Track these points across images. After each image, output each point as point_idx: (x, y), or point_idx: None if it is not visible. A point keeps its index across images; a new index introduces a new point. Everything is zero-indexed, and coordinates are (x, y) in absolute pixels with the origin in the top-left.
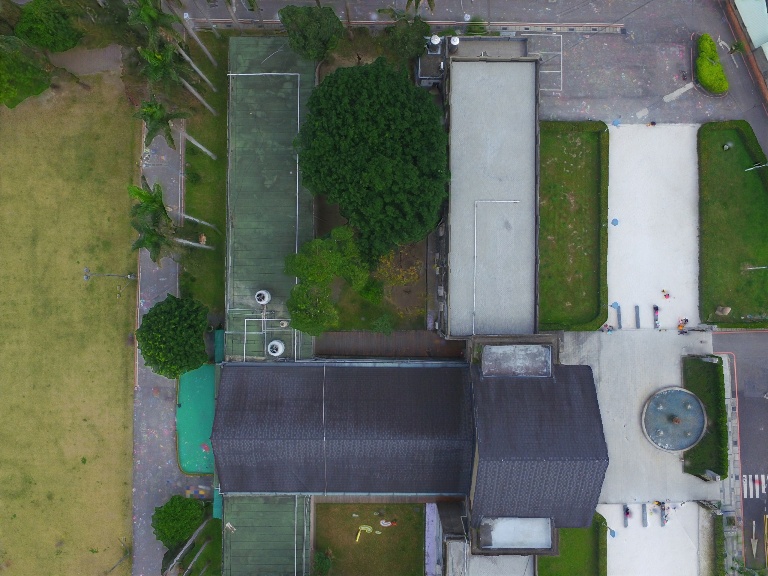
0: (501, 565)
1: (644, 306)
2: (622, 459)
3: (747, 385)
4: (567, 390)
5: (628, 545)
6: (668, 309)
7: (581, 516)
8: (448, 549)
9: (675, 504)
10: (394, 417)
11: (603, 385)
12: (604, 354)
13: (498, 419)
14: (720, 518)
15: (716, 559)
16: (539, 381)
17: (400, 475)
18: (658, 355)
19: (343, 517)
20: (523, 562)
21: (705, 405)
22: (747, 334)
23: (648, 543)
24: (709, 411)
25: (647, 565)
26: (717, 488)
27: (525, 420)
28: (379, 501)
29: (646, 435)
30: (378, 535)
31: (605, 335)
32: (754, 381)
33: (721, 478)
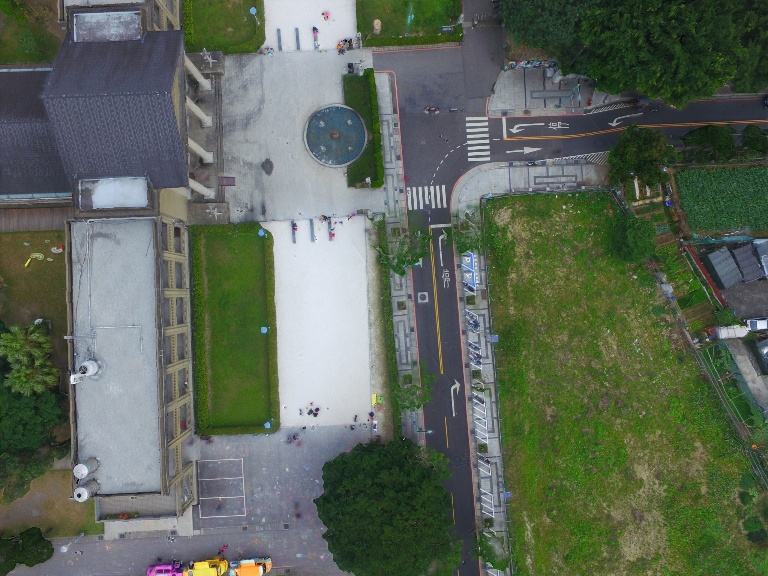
0: (124, 245)
1: (305, 29)
2: (288, 177)
3: (408, 101)
4: (151, 47)
5: (298, 261)
6: (328, 31)
7: (174, 172)
8: (66, 228)
9: (342, 219)
10: (13, 107)
11: (267, 106)
12: (267, 76)
13: (74, 69)
14: (381, 226)
15: (381, 267)
16: (126, 42)
17: (31, 170)
18: (319, 75)
19: (14, 246)
20: (145, 241)
21: (364, 119)
22: (406, 53)
23: (318, 258)
24: (366, 123)
25: (318, 280)
26: (381, 201)
27: (100, 69)
28: (49, 228)
29: (308, 151)
30: (50, 262)
31: (267, 58)
32: (414, 97)
33: (376, 183)
